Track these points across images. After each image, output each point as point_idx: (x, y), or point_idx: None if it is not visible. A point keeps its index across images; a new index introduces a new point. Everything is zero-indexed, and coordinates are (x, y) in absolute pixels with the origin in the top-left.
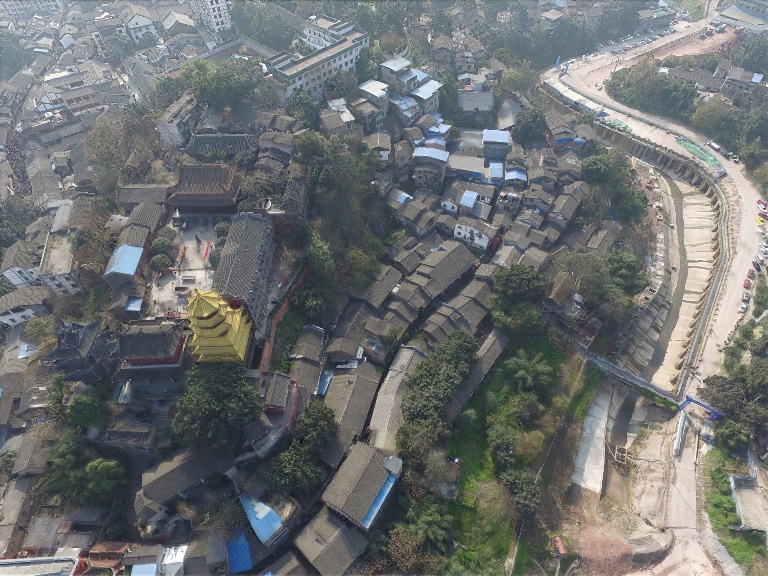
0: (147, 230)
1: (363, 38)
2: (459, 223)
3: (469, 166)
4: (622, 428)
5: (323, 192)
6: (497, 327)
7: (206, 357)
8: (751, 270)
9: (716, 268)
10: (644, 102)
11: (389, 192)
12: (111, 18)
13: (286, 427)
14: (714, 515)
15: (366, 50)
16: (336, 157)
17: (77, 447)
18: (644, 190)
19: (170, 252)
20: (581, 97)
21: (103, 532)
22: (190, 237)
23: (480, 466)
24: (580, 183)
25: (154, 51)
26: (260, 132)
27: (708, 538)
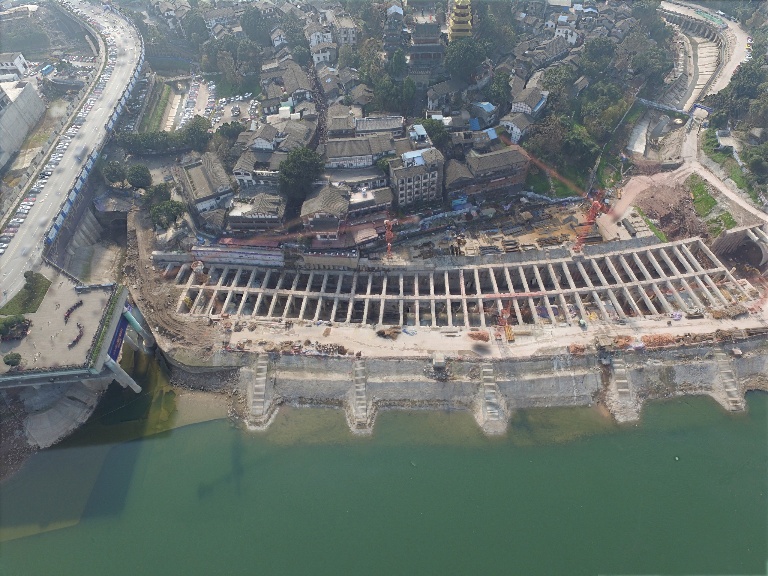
0: (400, 3)
1: None
2: (559, 28)
3: (562, 3)
4: (656, 135)
5: None
6: (586, 70)
7: (453, 40)
8: (738, 65)
9: (717, 67)
10: None
11: (515, 13)
12: None
13: (490, 78)
14: (706, 149)
15: None
16: None
17: (393, 79)
18: None
19: None
20: None
21: (406, 117)
22: (417, 14)
23: (579, 126)
24: (631, 18)
25: None
26: None
27: (703, 159)
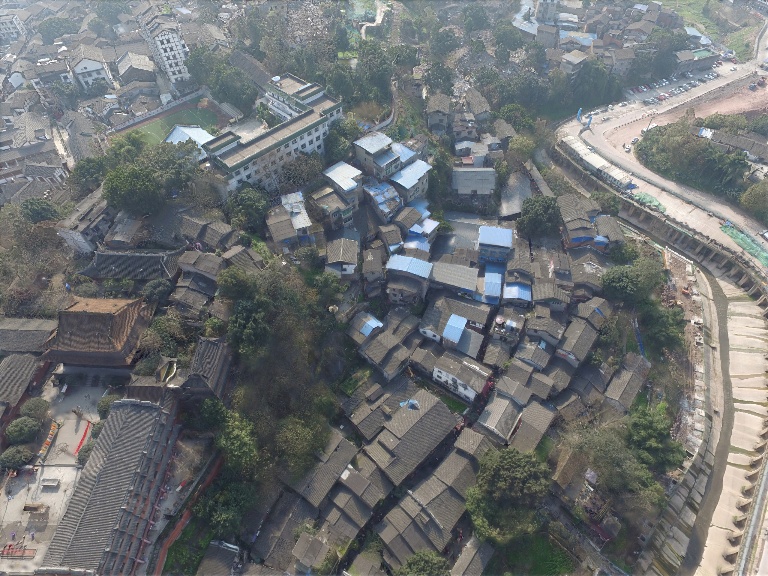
0: (3, 408)
1: (334, 109)
2: (439, 367)
3: (458, 279)
4: None
5: (247, 353)
6: (478, 539)
7: None
8: None
9: None
10: (681, 173)
11: (352, 318)
12: (56, 61)
13: None
14: None
15: (337, 124)
16: (276, 289)
17: None
18: (680, 302)
19: (33, 438)
20: (605, 163)
21: None
22: (71, 406)
23: None
24: (599, 302)
25: (100, 103)
26: (184, 247)
27: None
